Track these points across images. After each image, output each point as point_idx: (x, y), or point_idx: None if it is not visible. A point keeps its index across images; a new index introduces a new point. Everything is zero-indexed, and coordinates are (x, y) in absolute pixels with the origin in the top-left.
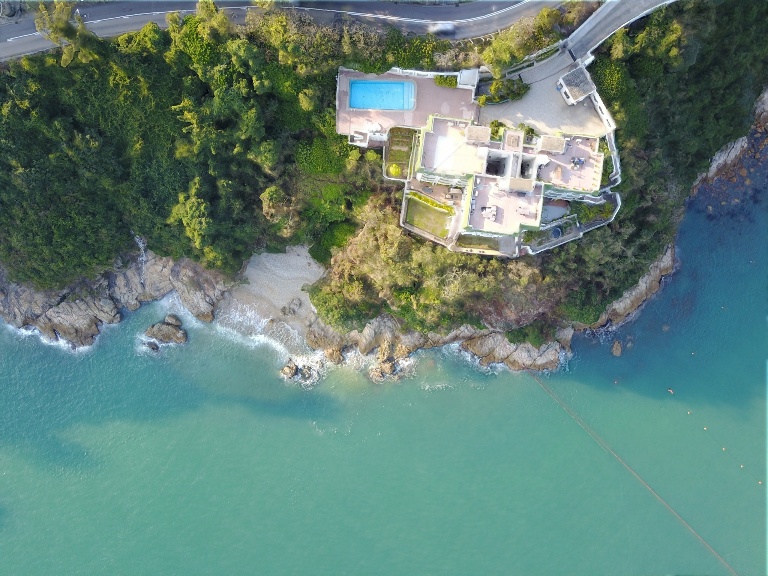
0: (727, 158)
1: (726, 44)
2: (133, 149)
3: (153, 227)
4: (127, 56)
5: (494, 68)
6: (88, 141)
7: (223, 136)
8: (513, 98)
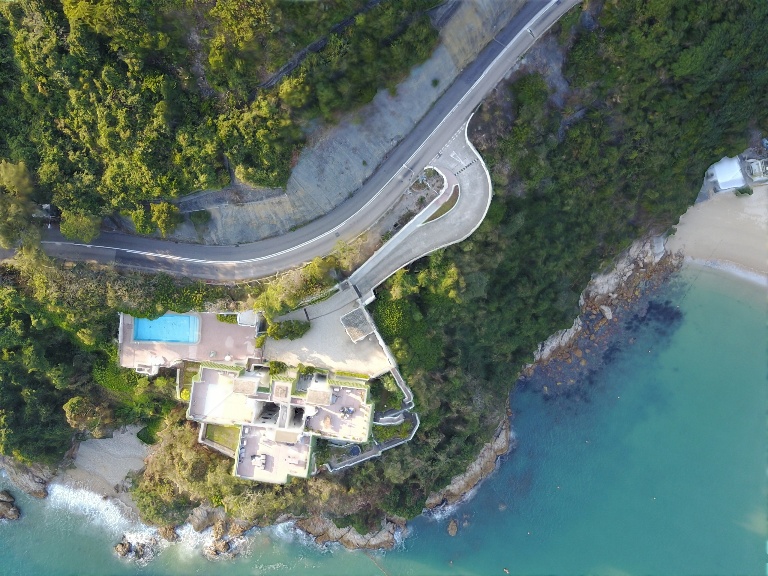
0: (561, 341)
1: (533, 257)
2: None
3: None
4: None
5: (267, 315)
6: None
7: (15, 359)
8: (292, 338)
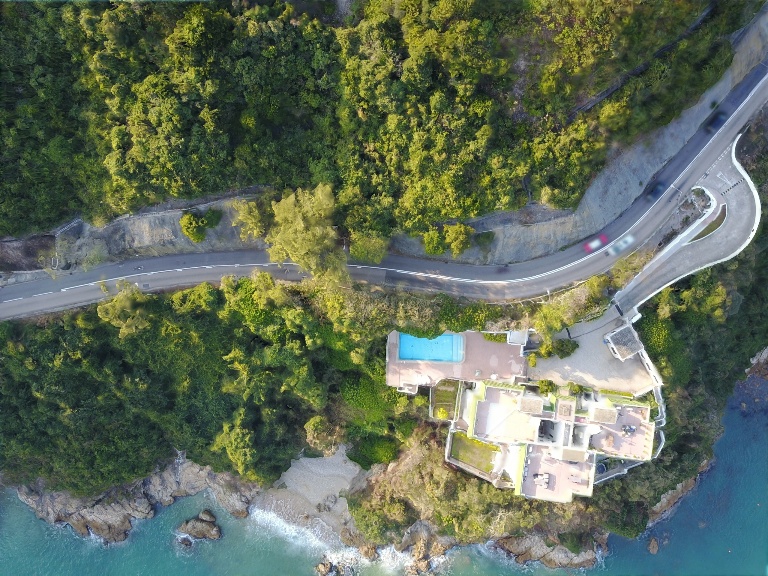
0: (760, 357)
1: (763, 274)
2: (180, 386)
3: (194, 445)
4: (181, 315)
5: (545, 334)
6: (137, 383)
7: (271, 378)
8: (562, 357)
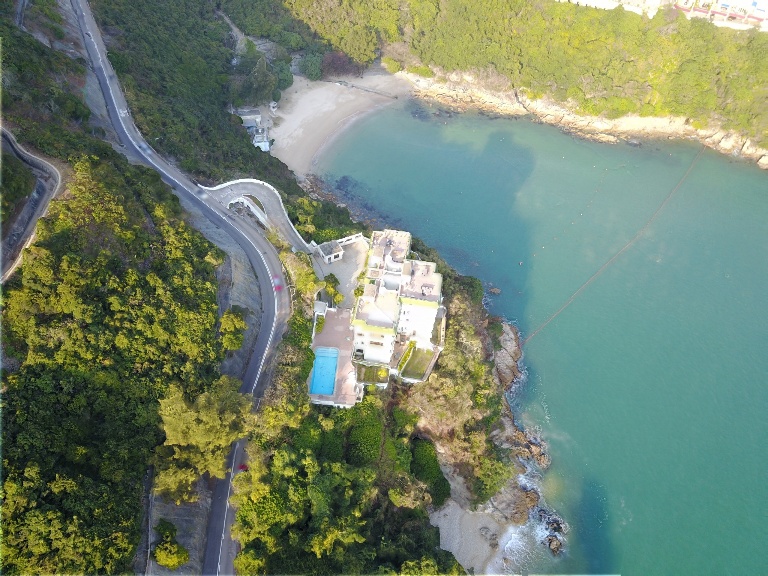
0: None
1: None
2: None
3: None
4: None
5: (319, 285)
6: None
7: None
8: (338, 283)
